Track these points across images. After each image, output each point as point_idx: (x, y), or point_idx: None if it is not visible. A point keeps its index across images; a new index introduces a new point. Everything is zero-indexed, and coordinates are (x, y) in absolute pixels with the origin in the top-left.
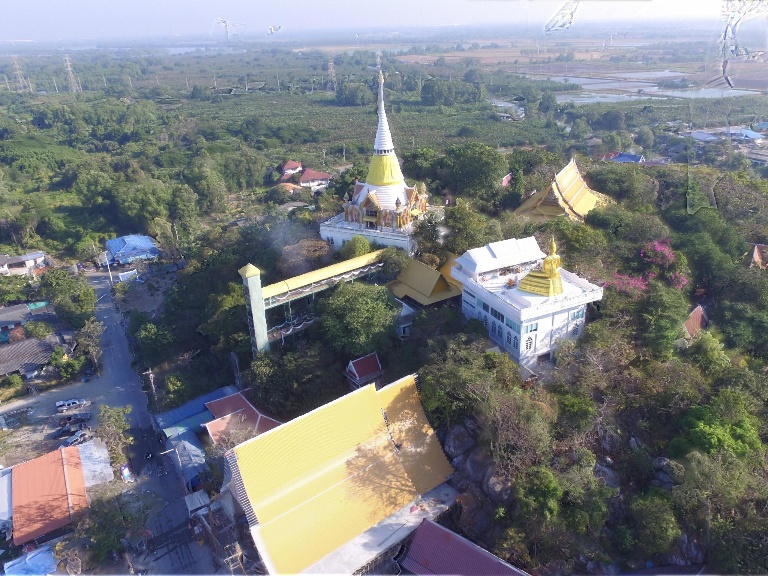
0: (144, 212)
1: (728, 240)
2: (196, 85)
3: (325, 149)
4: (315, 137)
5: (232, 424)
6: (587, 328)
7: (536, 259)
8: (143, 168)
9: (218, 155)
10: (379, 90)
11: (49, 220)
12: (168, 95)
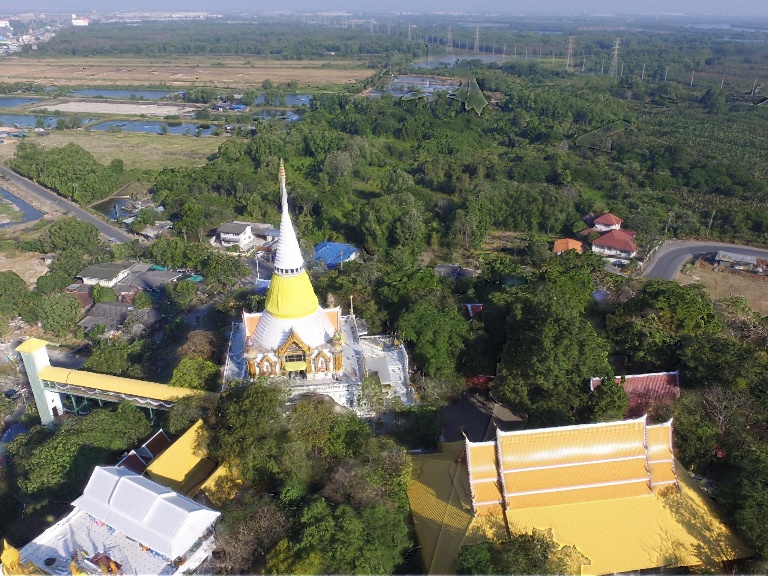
0: (363, 226)
1: None
2: (711, 88)
3: (673, 212)
4: (731, 188)
5: None
6: None
7: (156, 549)
8: (489, 175)
9: (515, 185)
10: None
11: (322, 205)
12: (675, 95)
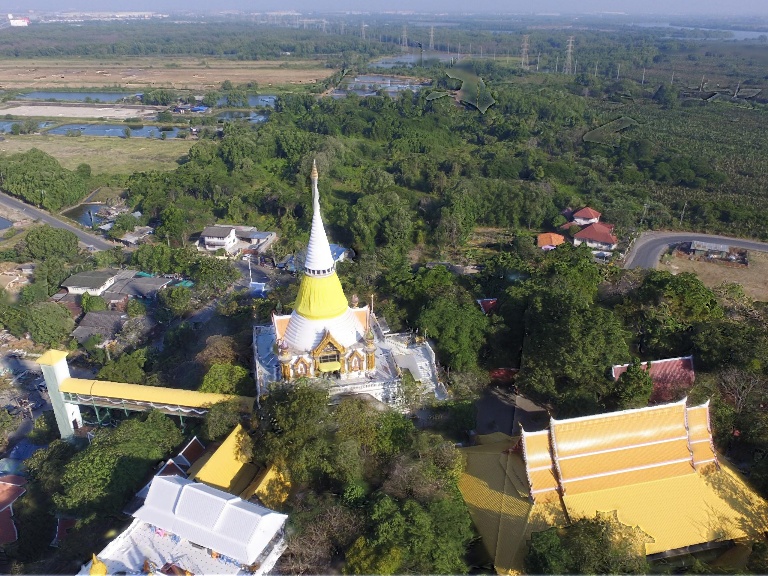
0: (351, 226)
1: None
2: (664, 85)
3: (648, 204)
4: (695, 181)
5: (4, 495)
6: None
7: (230, 555)
8: (465, 173)
9: (496, 182)
10: (312, 187)
11: (304, 207)
12: (630, 91)
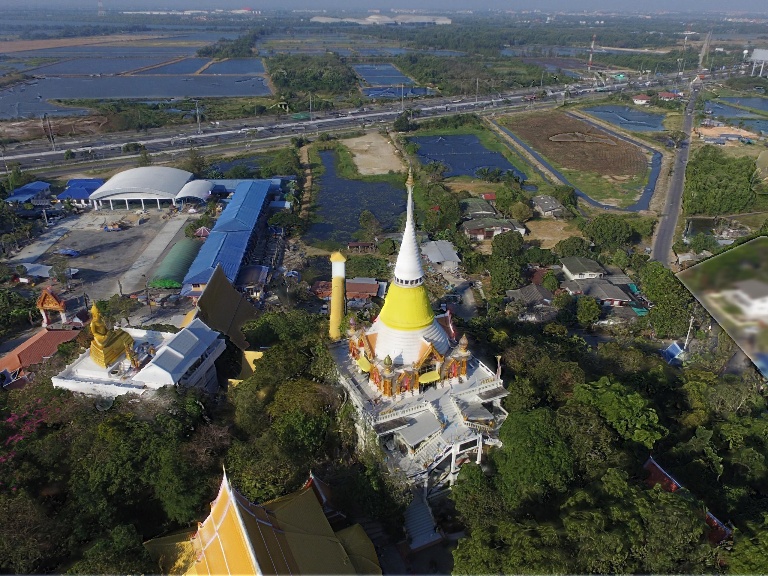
0: None
1: None
2: None
3: None
4: None
5: None
6: None
7: None
8: None
9: None
10: None
11: None
12: None
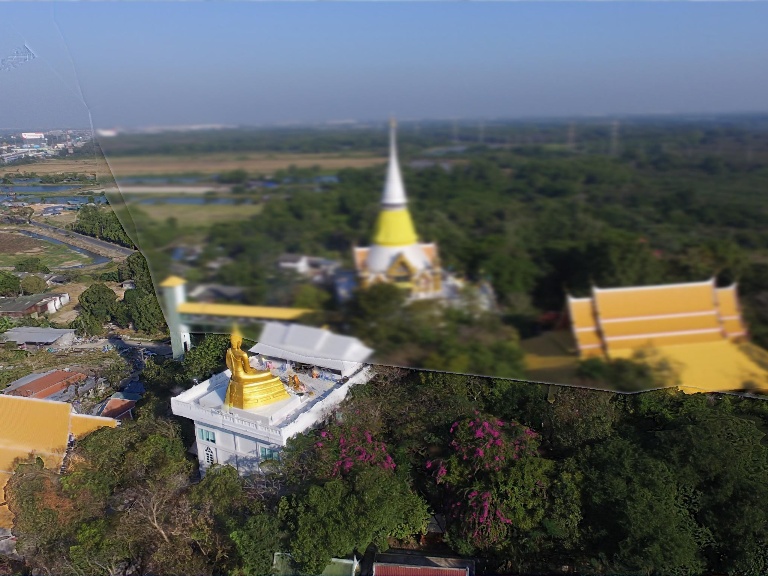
0: None
1: (739, 513)
2: None
3: None
4: None
5: (123, 408)
6: (212, 465)
7: (329, 367)
8: None
9: None
10: None
11: None
12: None
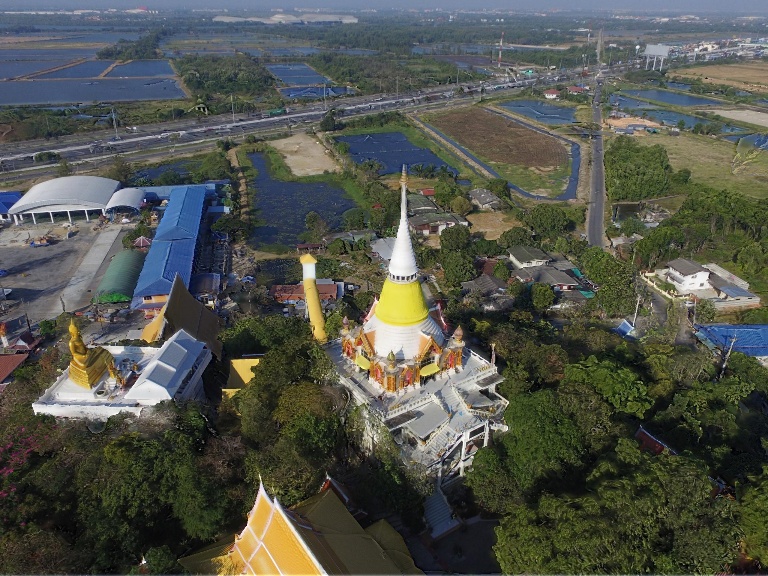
0: None
1: None
2: None
3: None
4: None
5: None
6: None
7: None
8: None
9: None
10: None
11: None
12: None
